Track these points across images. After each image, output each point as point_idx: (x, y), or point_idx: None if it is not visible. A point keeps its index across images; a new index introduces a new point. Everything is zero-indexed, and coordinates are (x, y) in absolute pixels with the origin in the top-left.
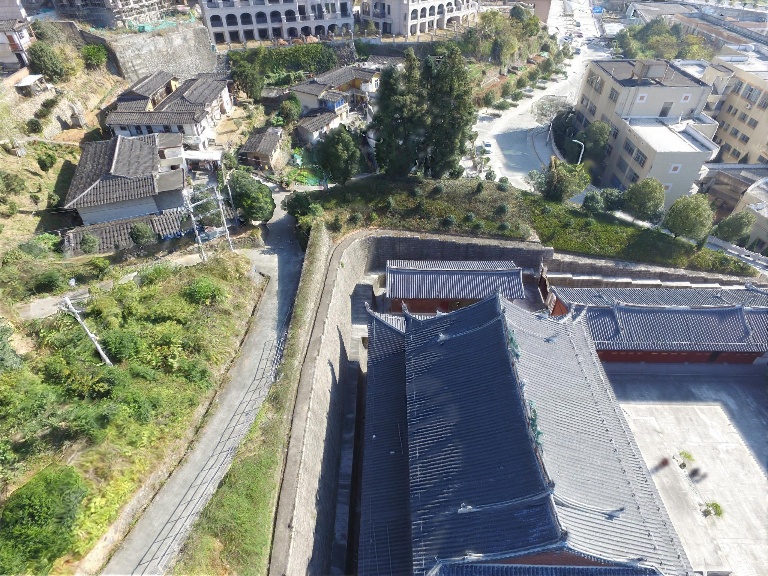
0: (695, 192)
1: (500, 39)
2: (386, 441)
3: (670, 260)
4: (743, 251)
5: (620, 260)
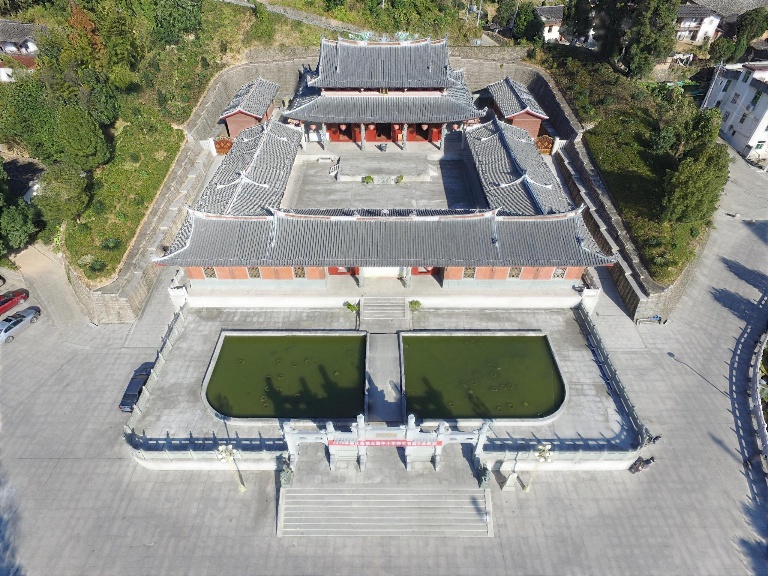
0: None
1: None
2: None
3: (622, 203)
4: (765, 338)
5: (602, 178)
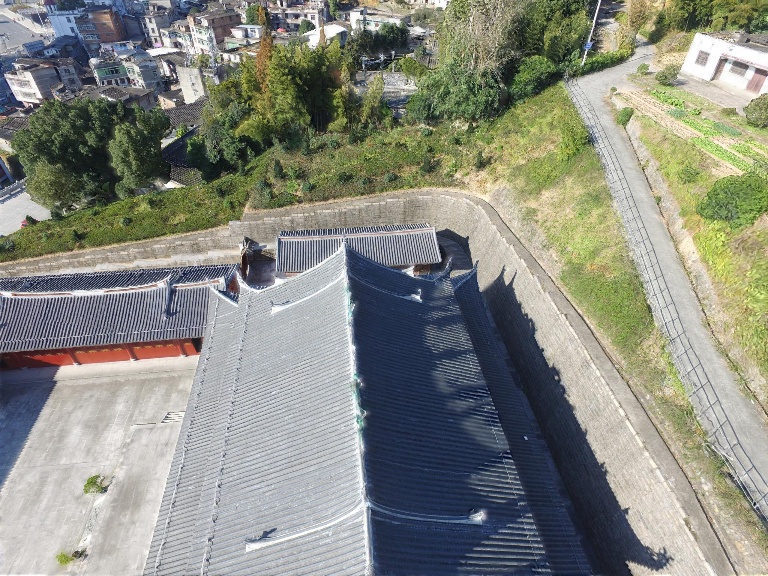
0: None
1: None
2: (508, 426)
3: None
4: None
5: None
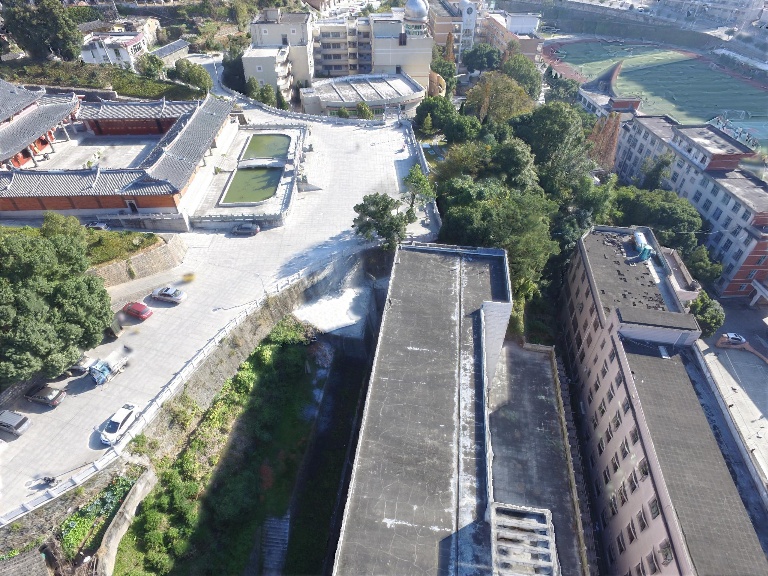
0: (285, 86)
1: (233, 5)
2: None
3: (185, 99)
4: (266, 106)
5: None
